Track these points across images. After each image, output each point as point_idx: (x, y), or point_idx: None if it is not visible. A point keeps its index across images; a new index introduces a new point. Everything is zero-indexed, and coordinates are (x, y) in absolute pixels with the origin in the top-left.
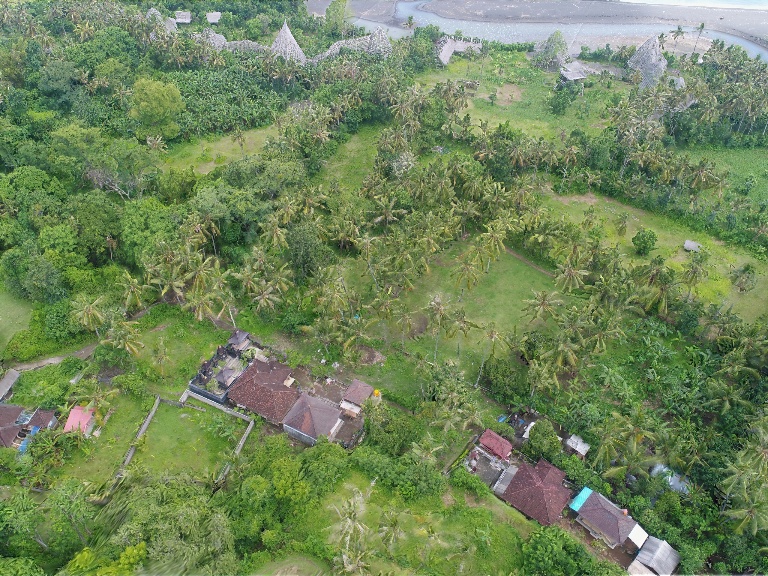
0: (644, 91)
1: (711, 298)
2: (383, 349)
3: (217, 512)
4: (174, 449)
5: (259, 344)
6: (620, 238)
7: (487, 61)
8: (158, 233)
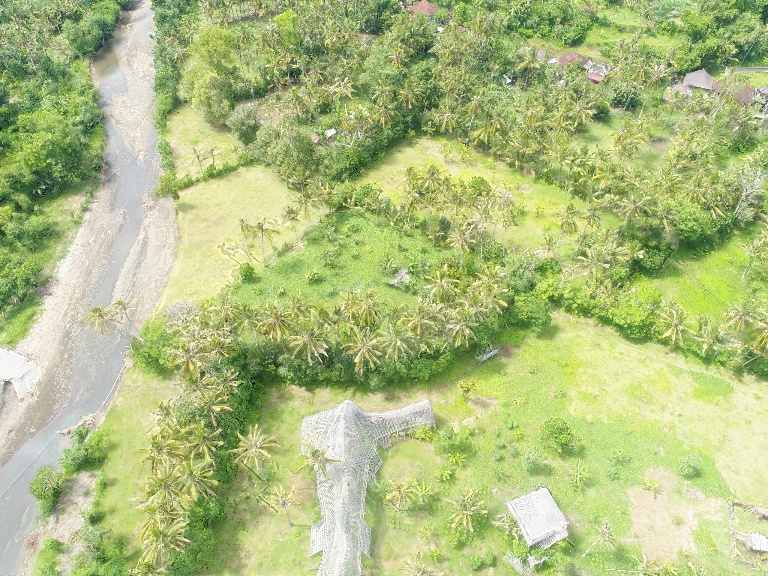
0: (379, 490)
1: (431, 162)
2: (675, 131)
3: (716, 3)
4: (760, 82)
5: (759, 117)
6: None
7: None
8: None
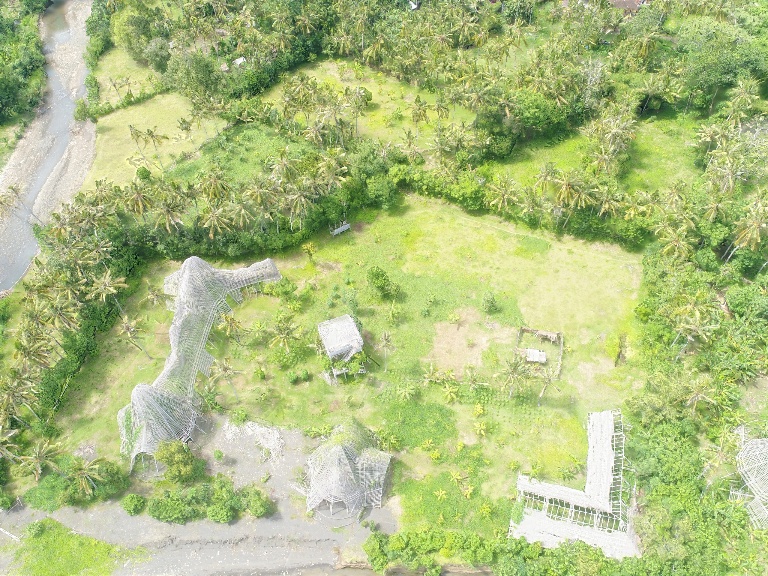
0: None
1: (328, 81)
2: None
3: None
4: None
5: None
6: (375, 117)
7: (497, 479)
8: (759, 9)
